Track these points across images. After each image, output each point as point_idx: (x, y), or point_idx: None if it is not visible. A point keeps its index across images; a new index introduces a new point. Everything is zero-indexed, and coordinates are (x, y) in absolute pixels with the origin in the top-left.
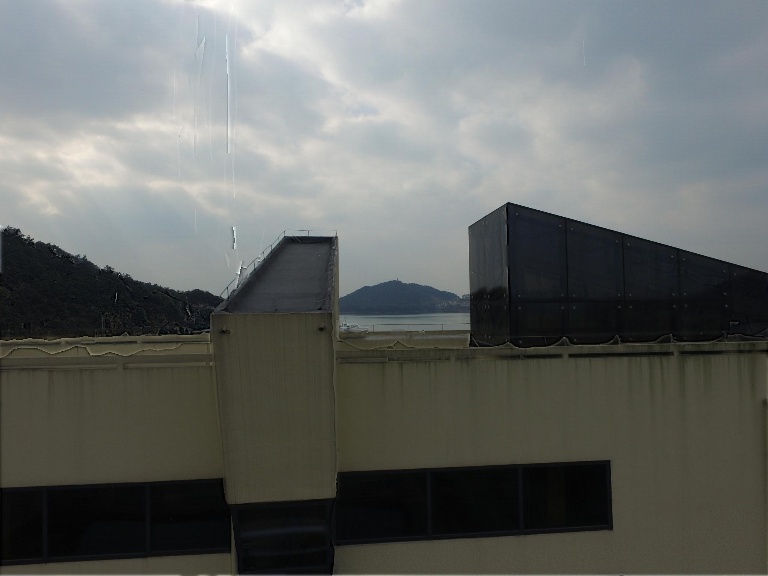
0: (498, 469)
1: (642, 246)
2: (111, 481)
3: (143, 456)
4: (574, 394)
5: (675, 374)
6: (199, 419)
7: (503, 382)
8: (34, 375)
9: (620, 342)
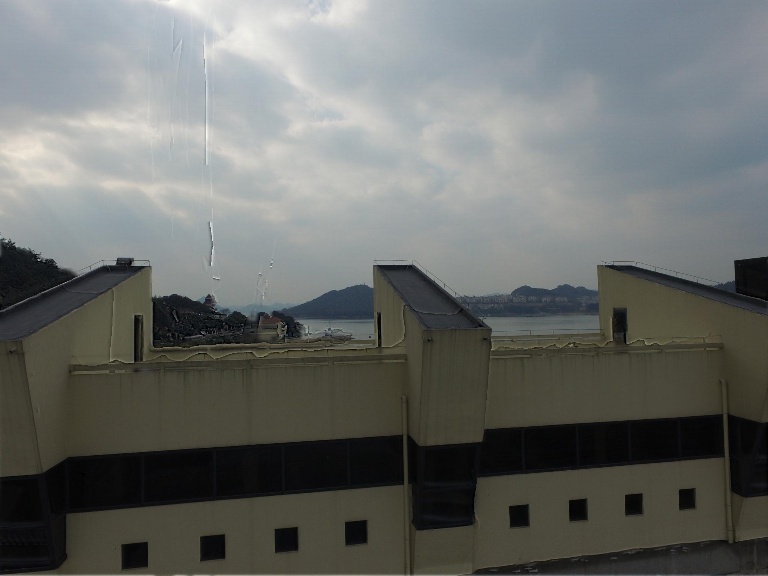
0: None
1: None
2: (662, 417)
3: (675, 403)
4: None
5: None
6: (702, 381)
7: None
8: (622, 356)
9: None
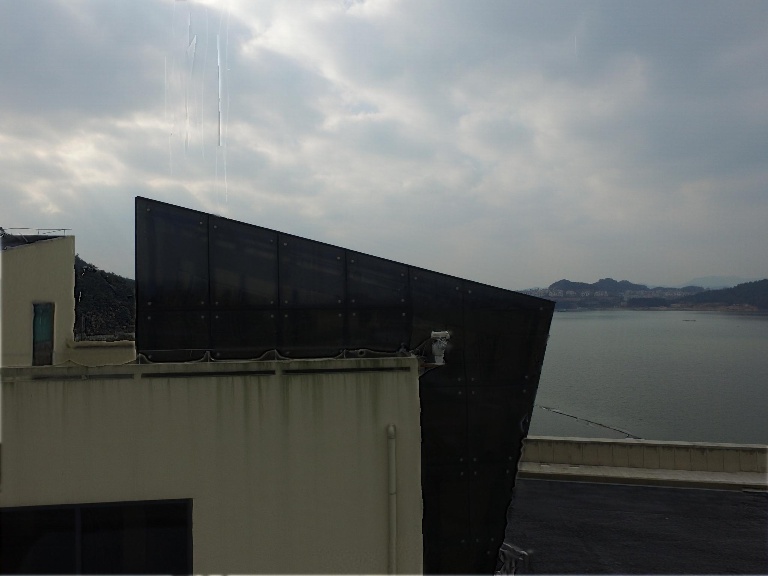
0: (49, 510)
1: (303, 246)
2: None
3: None
4: (149, 421)
5: (277, 397)
6: None
7: (57, 407)
8: None
9: (212, 359)
